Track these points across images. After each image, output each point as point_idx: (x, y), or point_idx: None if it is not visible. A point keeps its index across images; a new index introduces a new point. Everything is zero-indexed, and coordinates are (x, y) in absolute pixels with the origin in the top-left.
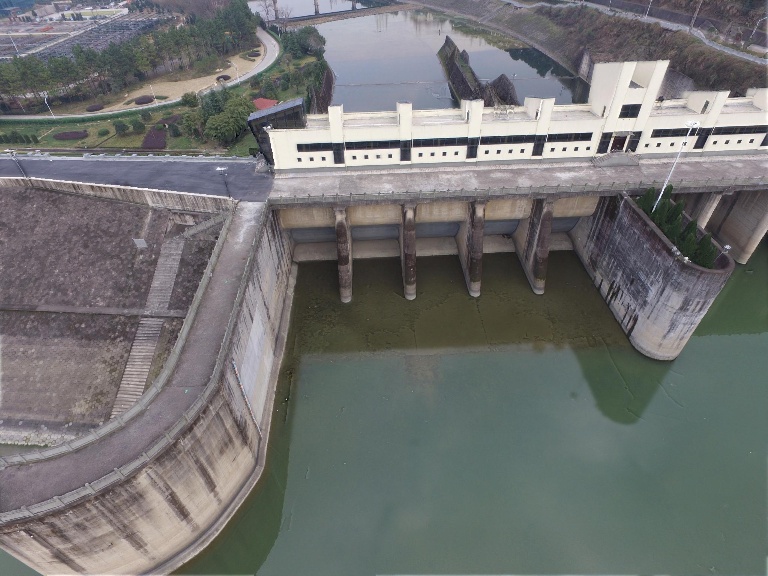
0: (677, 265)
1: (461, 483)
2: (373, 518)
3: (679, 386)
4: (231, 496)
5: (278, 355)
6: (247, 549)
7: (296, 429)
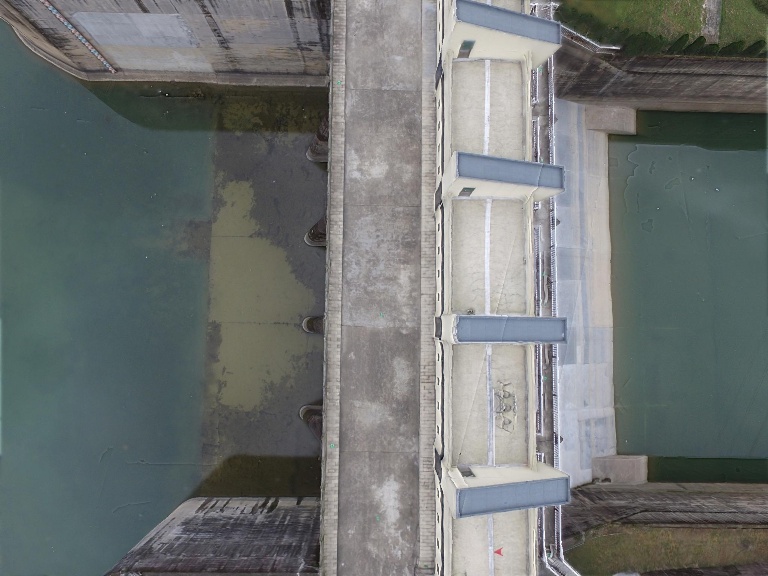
0: (122, 567)
1: (62, 260)
2: (32, 178)
3: (138, 523)
4: (48, 52)
5: (221, 77)
6: (108, 98)
7: (133, 108)
